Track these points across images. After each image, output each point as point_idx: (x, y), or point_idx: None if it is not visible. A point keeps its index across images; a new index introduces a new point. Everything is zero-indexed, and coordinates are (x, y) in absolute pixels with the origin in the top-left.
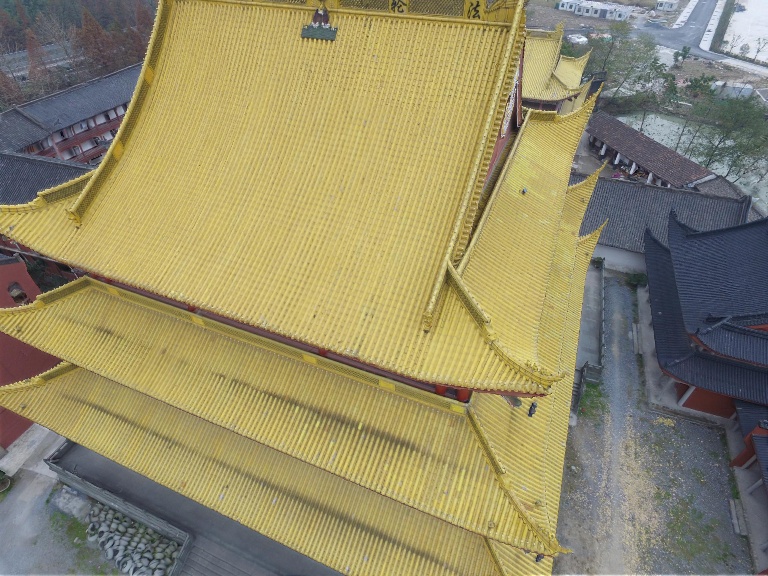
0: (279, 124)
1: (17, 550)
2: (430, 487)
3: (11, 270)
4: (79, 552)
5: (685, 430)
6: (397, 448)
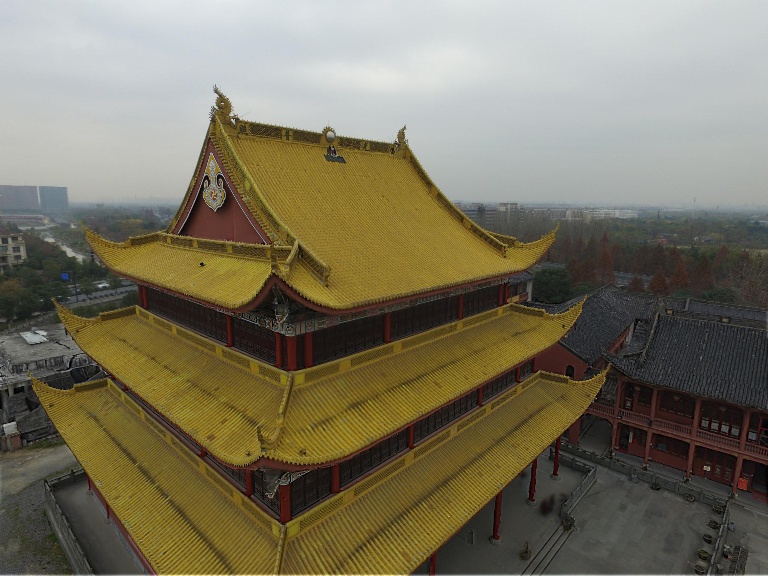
0: None
1: None
2: None
3: None
4: None
5: None
6: None
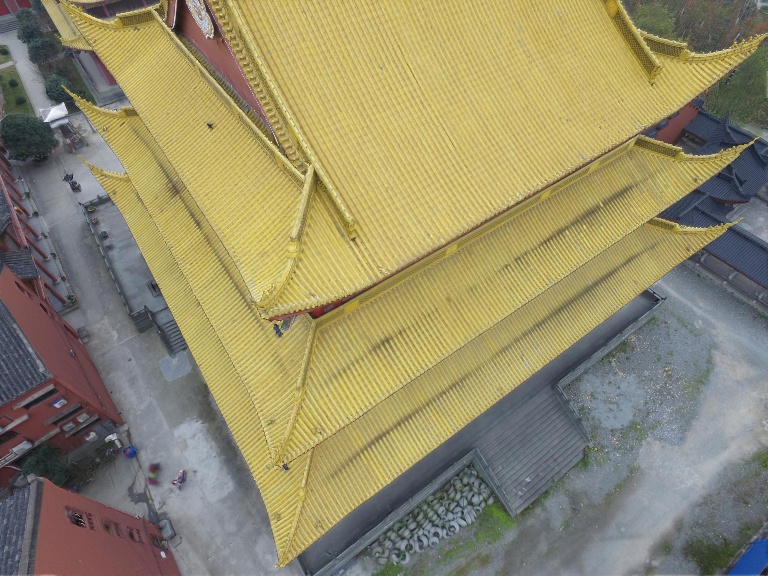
0: (425, 2)
1: None
2: None
3: (50, 499)
4: (414, 575)
5: None
6: (626, 195)
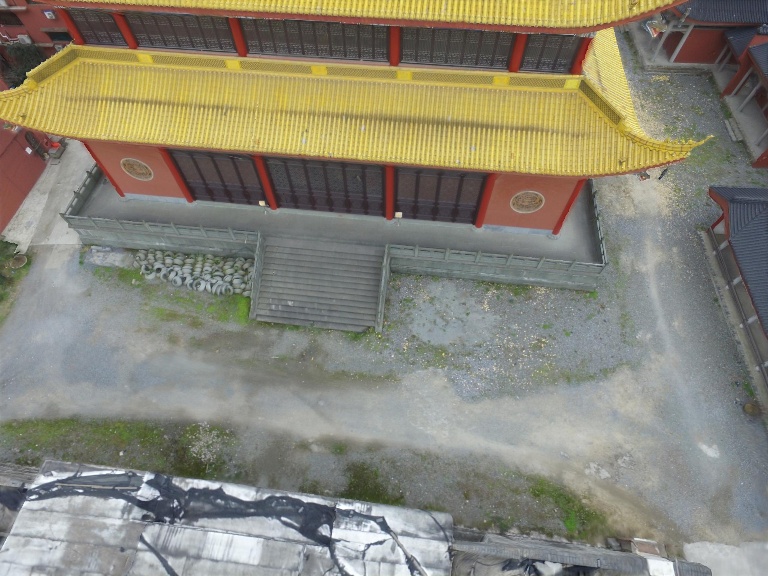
0: None
1: (73, 304)
2: (555, 5)
3: None
4: (143, 290)
5: (679, 81)
6: None
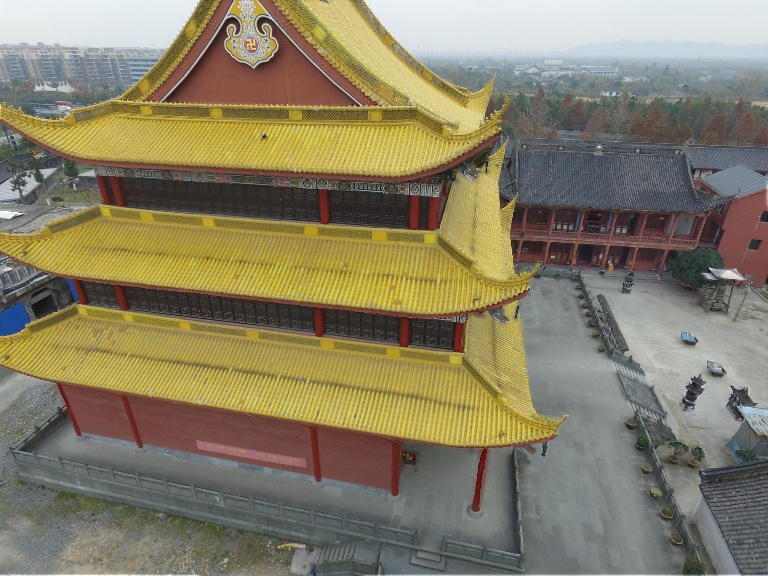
0: None
1: None
2: None
3: None
4: None
5: None
6: None
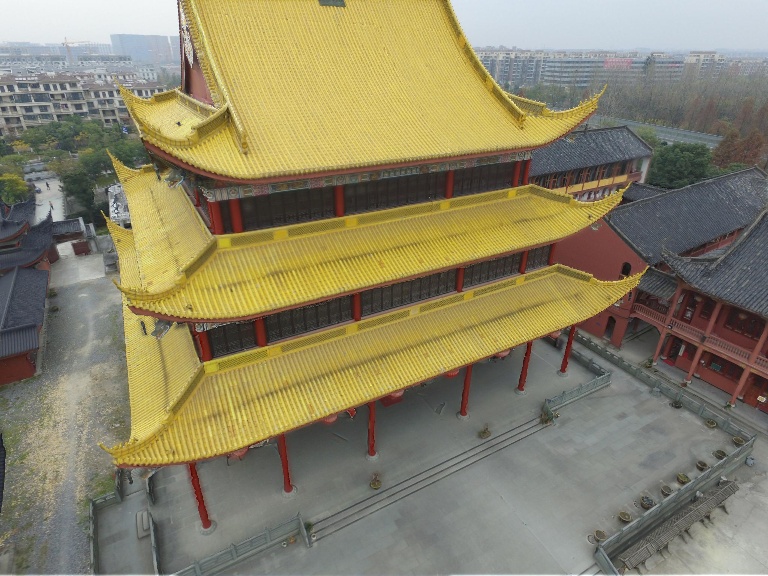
0: None
1: None
2: None
3: None
4: None
5: None
6: None
